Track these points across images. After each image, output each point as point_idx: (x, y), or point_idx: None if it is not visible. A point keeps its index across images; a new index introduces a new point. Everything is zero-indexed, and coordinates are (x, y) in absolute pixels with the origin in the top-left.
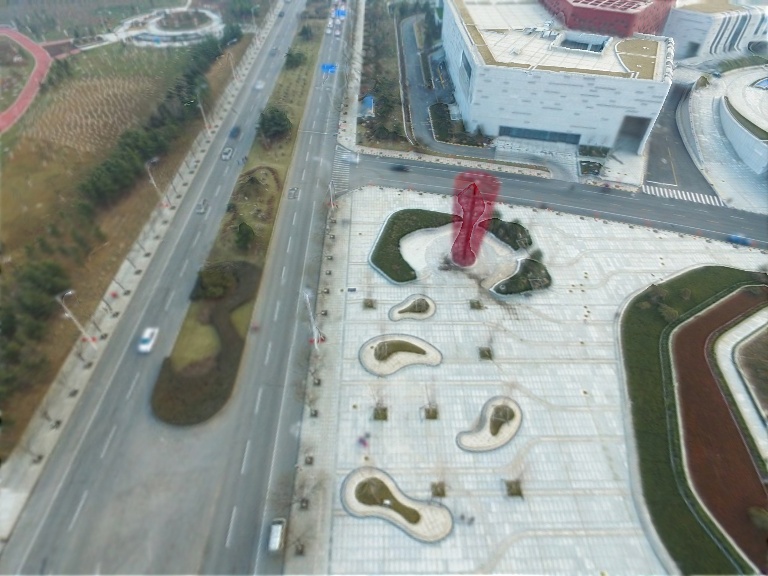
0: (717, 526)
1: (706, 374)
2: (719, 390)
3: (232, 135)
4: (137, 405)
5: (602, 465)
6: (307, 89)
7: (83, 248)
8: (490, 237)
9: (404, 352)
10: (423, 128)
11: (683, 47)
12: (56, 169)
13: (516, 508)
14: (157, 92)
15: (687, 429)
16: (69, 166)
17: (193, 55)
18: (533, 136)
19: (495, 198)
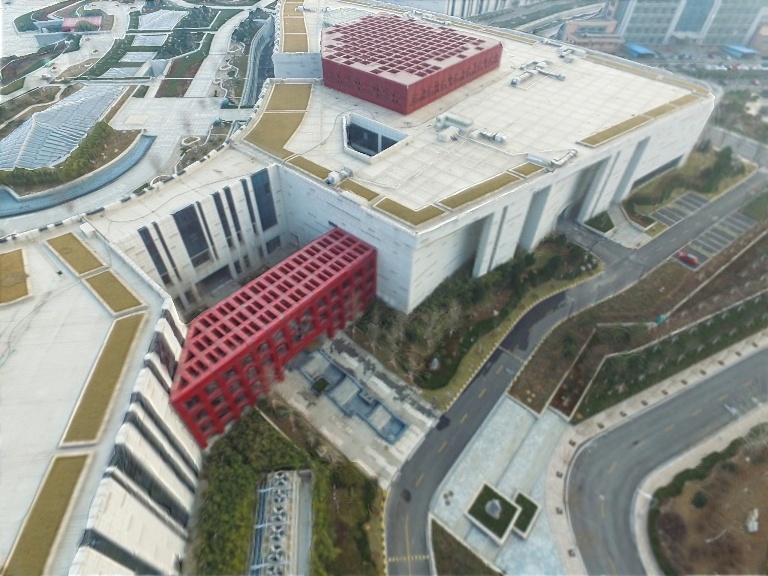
0: None
1: (72, 3)
2: None
3: None
4: None
5: None
6: None
7: None
8: None
9: None
10: None
11: None
12: None
13: None
14: None
15: None
16: None
17: None
18: None
19: None
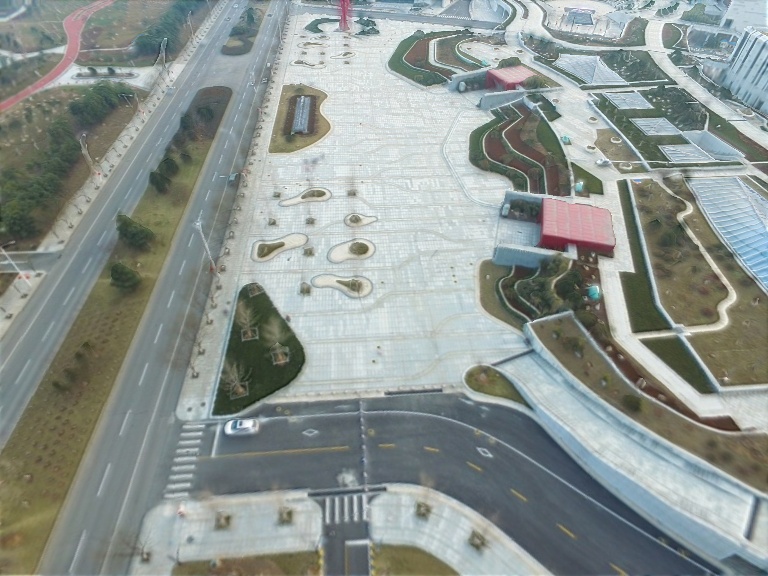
0: None
1: None
2: None
3: (237, 1)
4: (216, 53)
5: None
6: None
7: (181, 22)
8: (358, 25)
9: None
10: (337, 1)
11: None
12: (153, 8)
13: (346, 65)
14: None
15: None
16: (160, 7)
17: None
18: (392, 1)
19: None
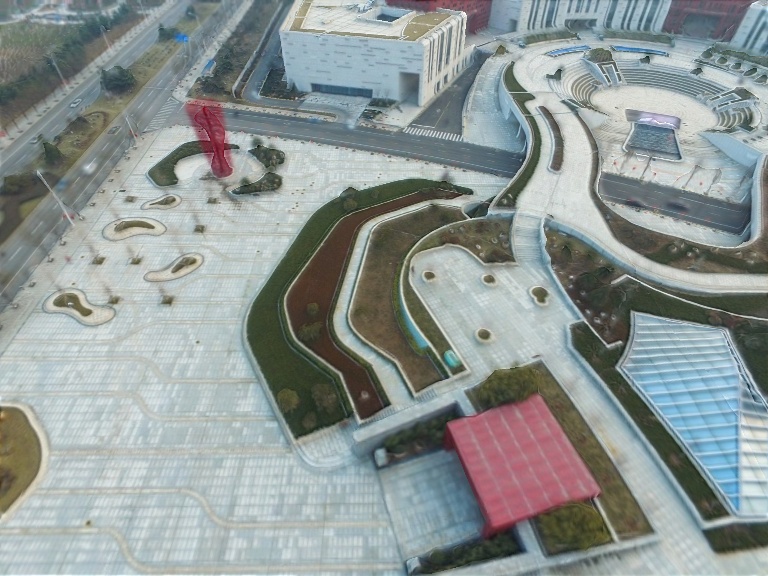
0: (286, 316)
1: (347, 238)
2: (348, 247)
3: (87, 90)
4: None
5: (240, 289)
6: (169, 56)
7: None
8: (253, 159)
9: (138, 227)
10: (254, 87)
11: (506, 24)
12: None
13: (162, 310)
14: (34, 57)
15: (308, 268)
16: None
17: (80, 29)
18: (338, 92)
19: (276, 134)
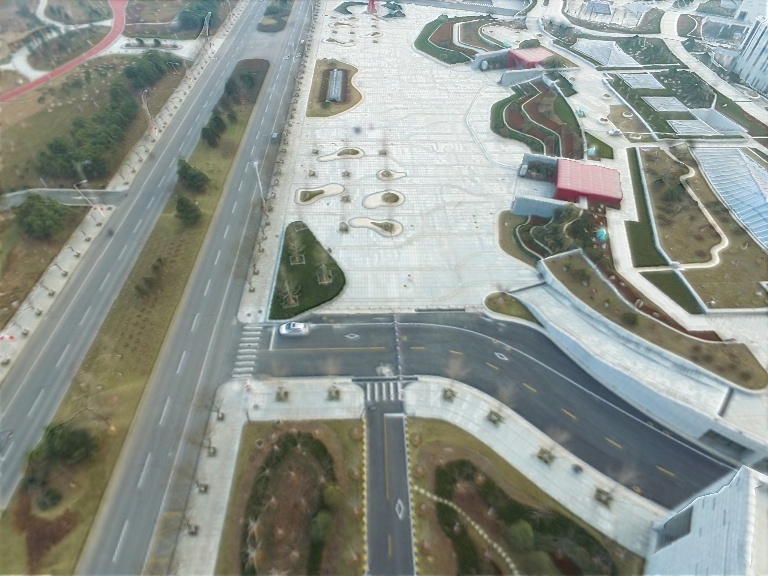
0: None
1: None
2: (450, 29)
3: None
4: None
5: None
6: None
7: (218, 1)
8: (385, 8)
9: (345, 25)
10: None
11: None
12: None
13: (375, 44)
14: None
15: None
16: None
17: None
18: None
19: (391, 1)
